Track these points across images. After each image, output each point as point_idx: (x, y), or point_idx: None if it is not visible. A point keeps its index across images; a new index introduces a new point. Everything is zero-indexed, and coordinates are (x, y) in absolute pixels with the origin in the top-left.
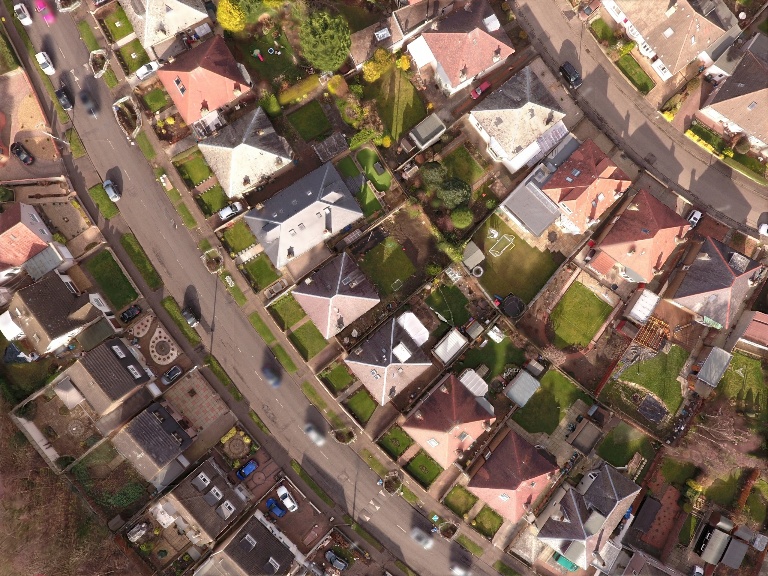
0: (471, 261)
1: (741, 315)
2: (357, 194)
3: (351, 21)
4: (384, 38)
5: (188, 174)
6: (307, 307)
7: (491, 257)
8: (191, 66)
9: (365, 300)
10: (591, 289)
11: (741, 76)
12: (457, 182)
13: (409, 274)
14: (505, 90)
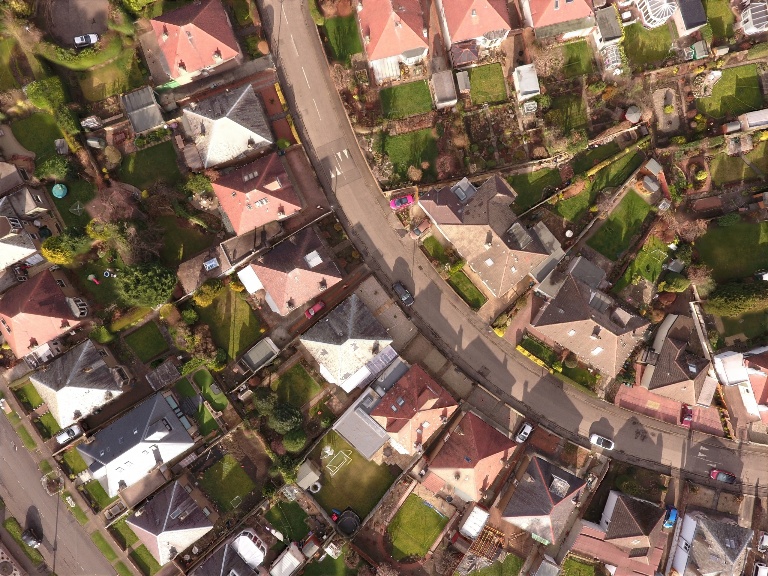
0: (305, 482)
1: (574, 522)
2: (195, 414)
3: (186, 243)
4: (213, 268)
5: (26, 397)
6: (140, 536)
7: (329, 472)
8: (14, 310)
9: (196, 530)
10: (427, 501)
11: (562, 301)
12: (286, 411)
13: (248, 491)
14: (331, 320)
